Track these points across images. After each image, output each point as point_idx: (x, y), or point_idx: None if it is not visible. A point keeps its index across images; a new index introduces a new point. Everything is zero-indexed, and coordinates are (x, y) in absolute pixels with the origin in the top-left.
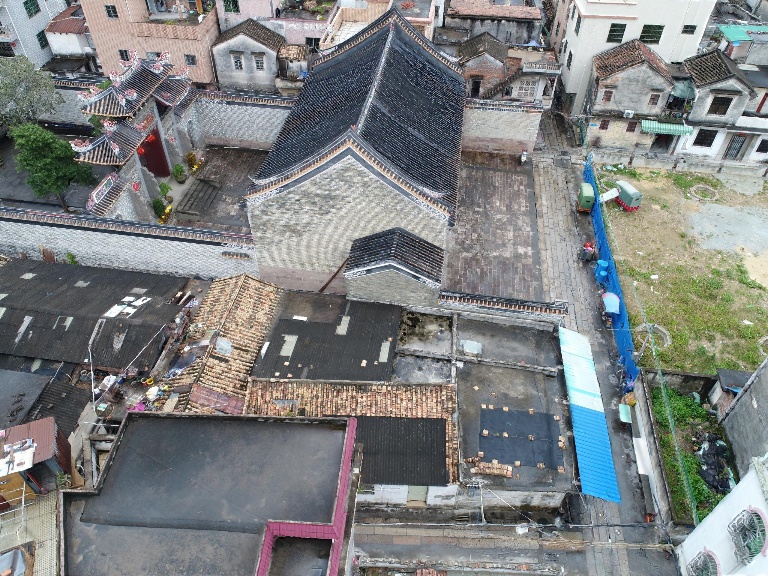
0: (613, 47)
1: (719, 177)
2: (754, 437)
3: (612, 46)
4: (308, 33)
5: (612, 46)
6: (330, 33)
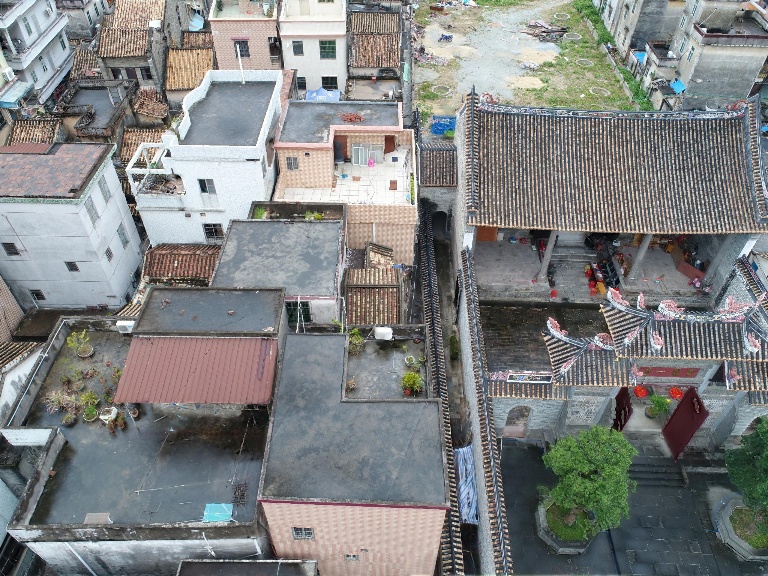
0: (348, 49)
1: (420, 81)
2: (710, 90)
3: (346, 49)
4: (345, 237)
5: (346, 49)
6: (373, 203)
